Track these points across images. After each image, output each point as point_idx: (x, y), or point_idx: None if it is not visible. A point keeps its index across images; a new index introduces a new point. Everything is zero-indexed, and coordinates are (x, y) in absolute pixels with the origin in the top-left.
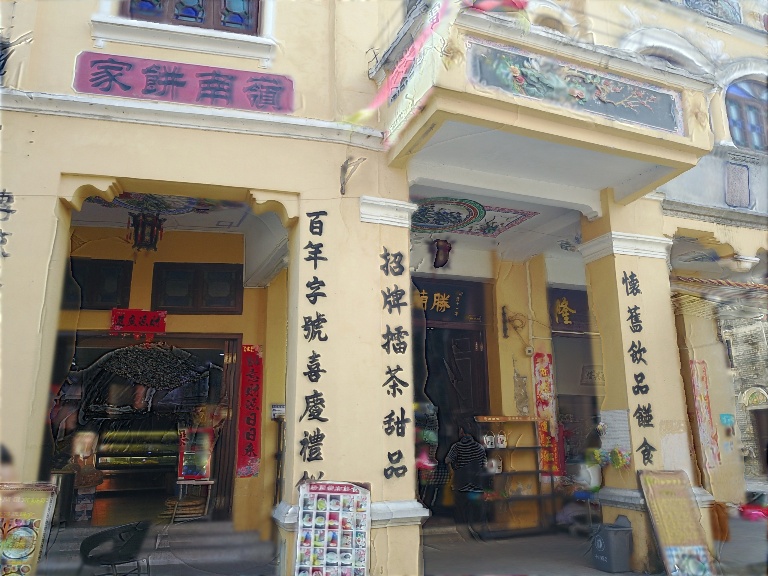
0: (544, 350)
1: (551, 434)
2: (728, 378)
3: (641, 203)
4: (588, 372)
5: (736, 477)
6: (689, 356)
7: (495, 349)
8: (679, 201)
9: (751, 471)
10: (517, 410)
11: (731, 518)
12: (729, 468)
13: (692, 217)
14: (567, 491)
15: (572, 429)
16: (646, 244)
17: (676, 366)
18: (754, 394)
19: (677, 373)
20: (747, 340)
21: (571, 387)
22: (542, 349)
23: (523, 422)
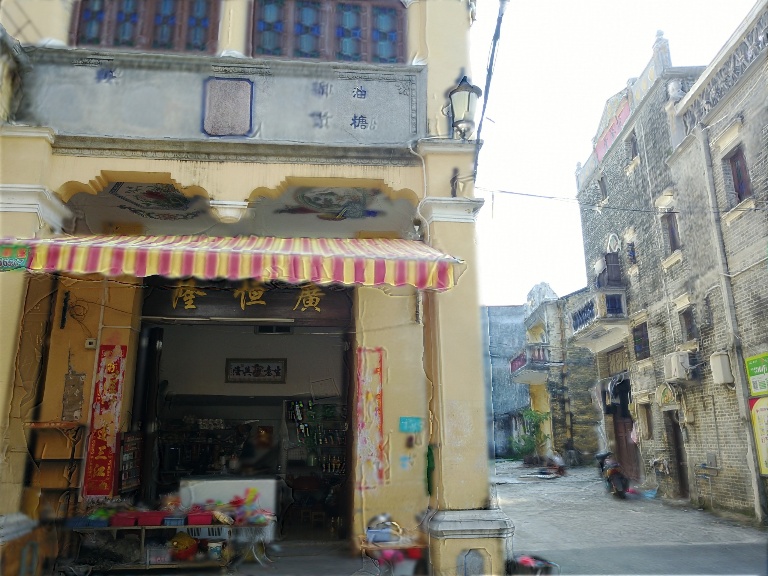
0: (116, 341)
1: (107, 443)
2: (422, 369)
3: (9, 143)
4: (234, 367)
5: (412, 501)
6: (358, 342)
7: (46, 342)
8: (96, 136)
9: (666, 491)
10: (59, 414)
11: (361, 557)
12: (401, 489)
13: (132, 155)
14: (82, 515)
15: (225, 437)
16: (1, 195)
17: (8, 353)
18: (664, 390)
19: (8, 362)
20: (658, 320)
21: (213, 386)
22: (113, 340)
23: (38, 429)
